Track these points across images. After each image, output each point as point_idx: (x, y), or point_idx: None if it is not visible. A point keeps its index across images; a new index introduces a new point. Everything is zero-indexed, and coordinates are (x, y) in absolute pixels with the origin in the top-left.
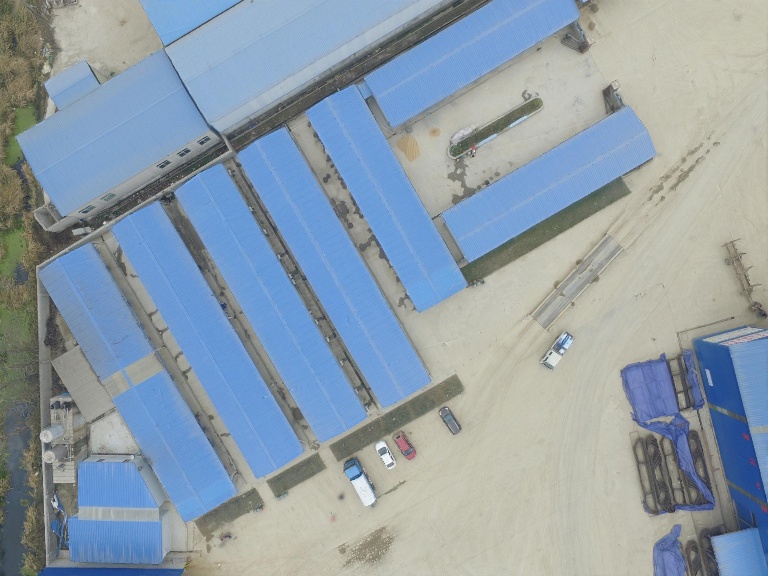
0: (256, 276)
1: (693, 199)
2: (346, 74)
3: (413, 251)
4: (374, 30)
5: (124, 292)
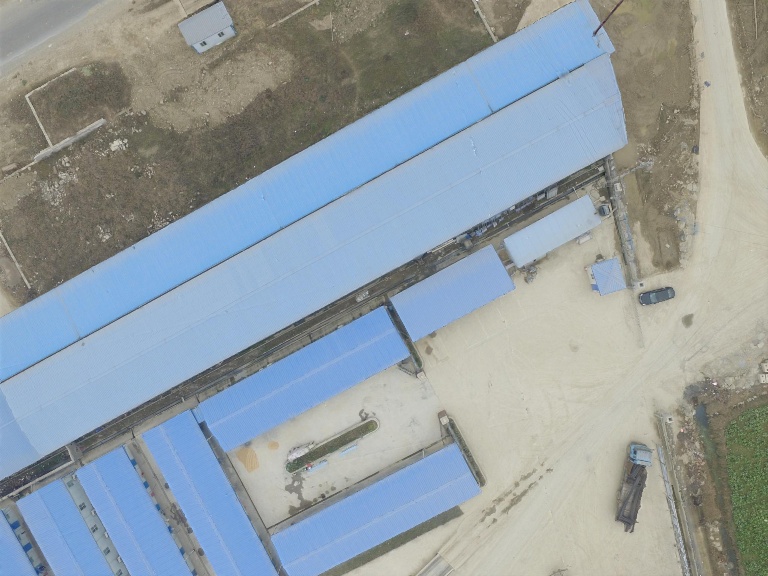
0: None
1: (525, 523)
2: (189, 385)
3: (240, 575)
4: None
5: None
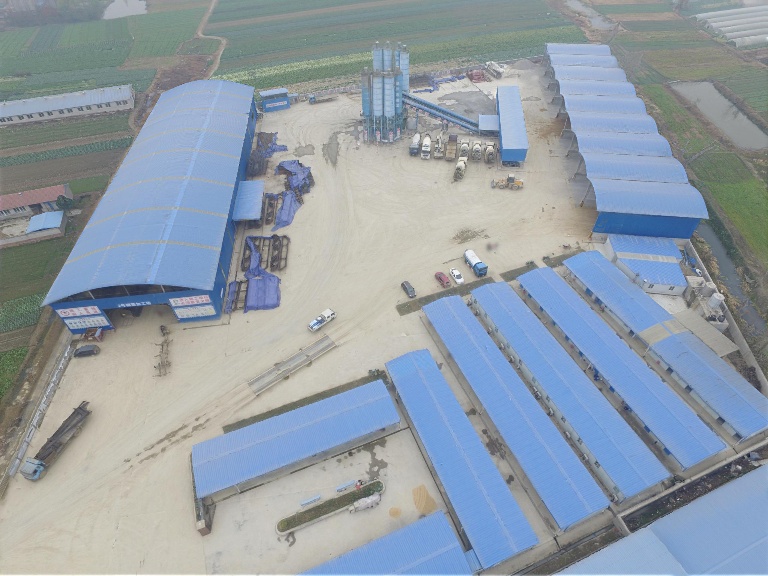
0: (570, 388)
1: (172, 415)
2: None
3: (430, 391)
4: None
5: (695, 401)
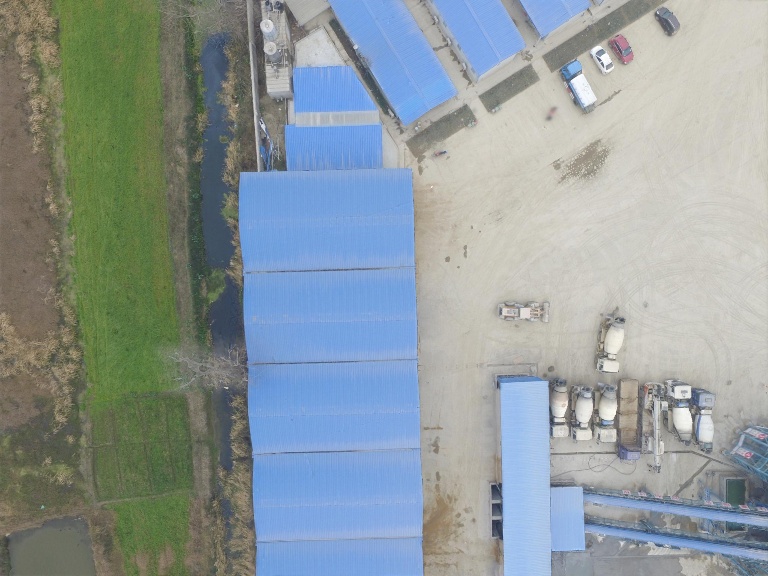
0: None
1: None
2: None
3: None
4: None
5: None
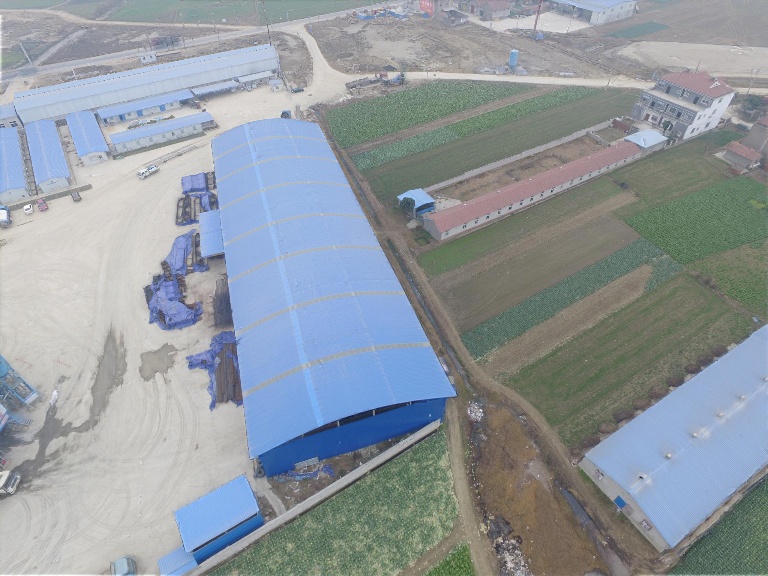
0: (4, 149)
1: None
2: None
3: None
4: (105, 97)
5: None
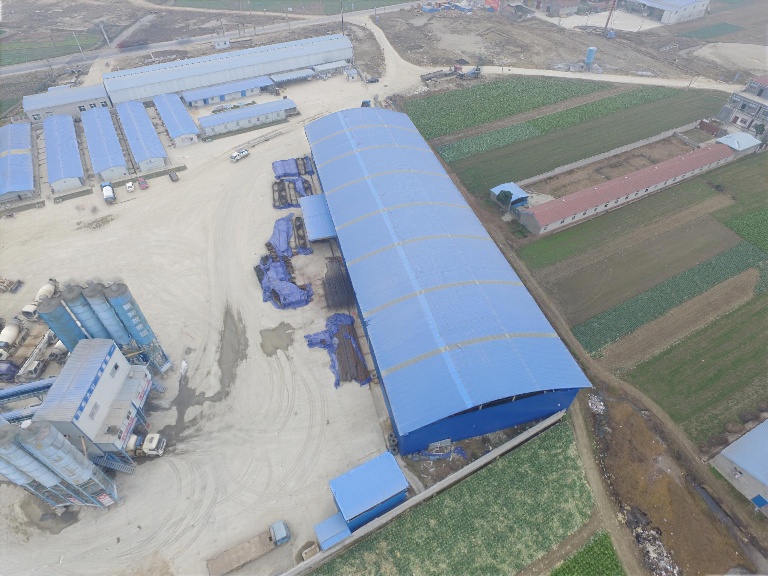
0: (100, 128)
1: None
2: None
3: None
4: (189, 81)
5: (32, 143)
